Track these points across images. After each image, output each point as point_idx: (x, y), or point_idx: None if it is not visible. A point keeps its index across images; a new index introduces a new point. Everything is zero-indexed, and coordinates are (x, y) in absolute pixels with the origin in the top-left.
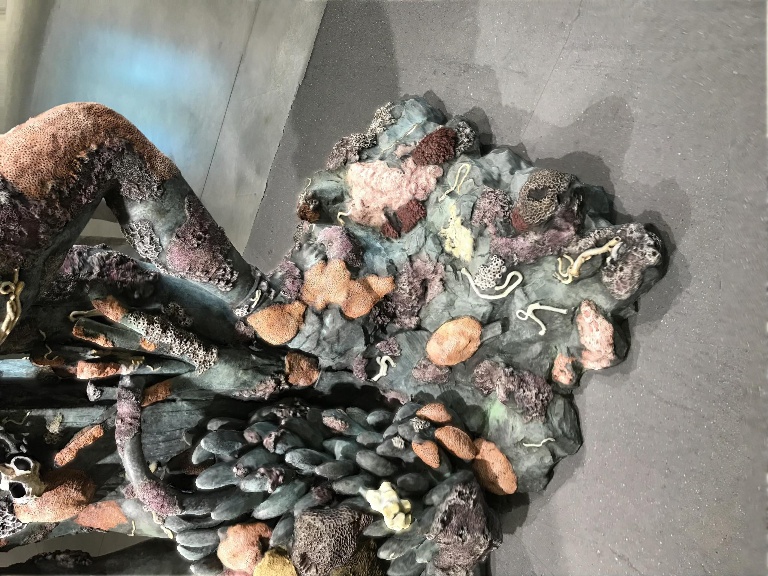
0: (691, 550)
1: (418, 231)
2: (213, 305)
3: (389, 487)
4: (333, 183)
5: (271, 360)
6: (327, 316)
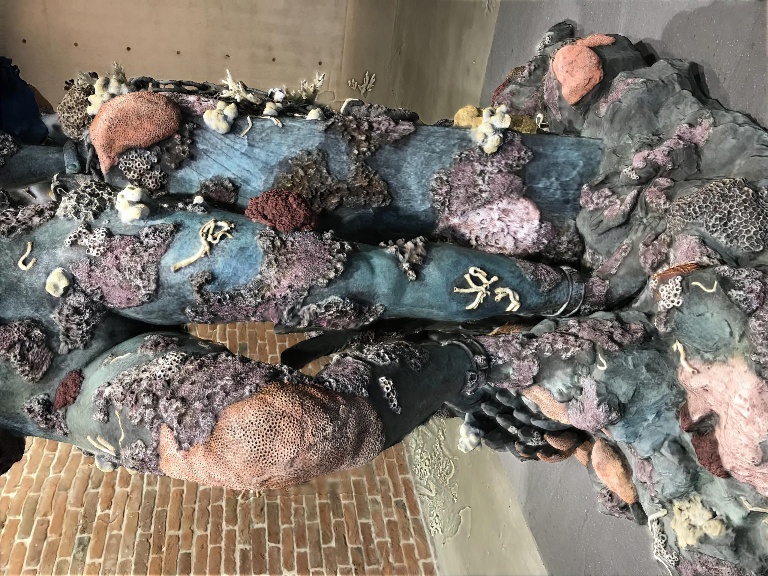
0: (595, 573)
1: (678, 476)
2: (437, 318)
3: (476, 441)
4: (722, 332)
5: (479, 329)
6: (527, 399)
